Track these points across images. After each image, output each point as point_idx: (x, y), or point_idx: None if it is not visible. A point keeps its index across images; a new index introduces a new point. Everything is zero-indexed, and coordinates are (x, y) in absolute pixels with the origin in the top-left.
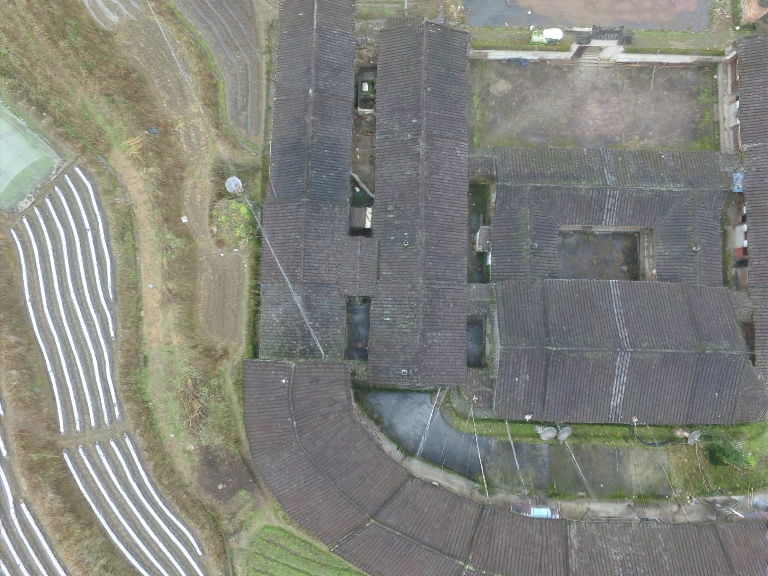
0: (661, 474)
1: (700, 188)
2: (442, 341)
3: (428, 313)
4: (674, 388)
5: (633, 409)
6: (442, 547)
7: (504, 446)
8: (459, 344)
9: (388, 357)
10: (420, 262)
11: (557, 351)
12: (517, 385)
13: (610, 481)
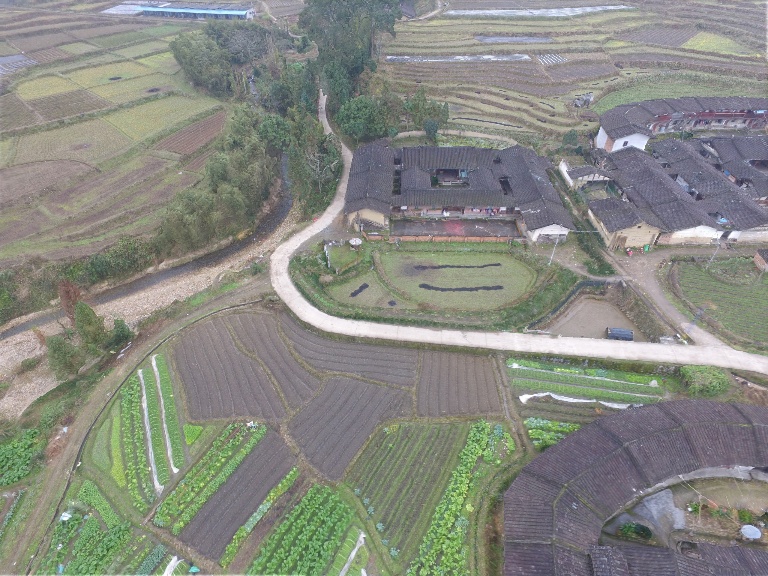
0: None
1: (765, 179)
2: None
3: None
4: None
5: None
6: None
7: None
8: None
9: None
10: None
11: None
12: None
13: (721, 133)
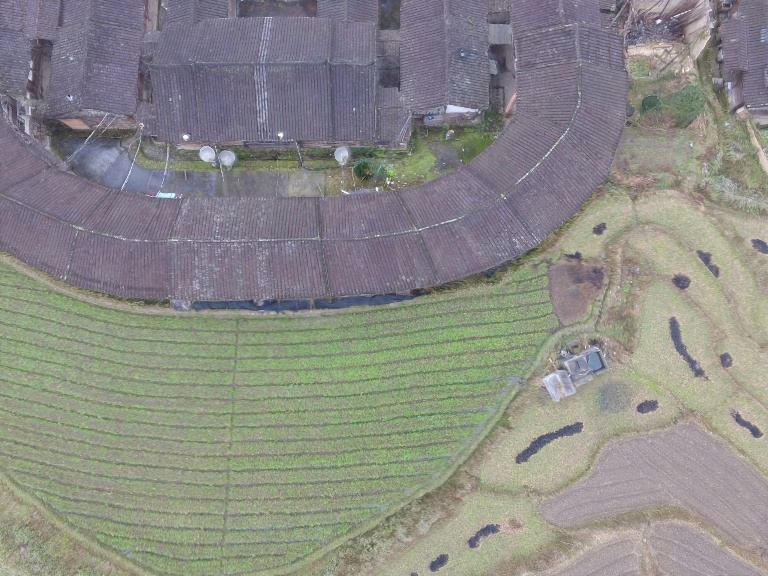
0: (317, 192)
1: None
2: (109, 73)
3: (95, 47)
4: (312, 102)
5: (279, 125)
6: (60, 215)
7: (177, 174)
8: (128, 78)
9: (61, 89)
10: (90, 4)
11: (197, 66)
12: (172, 106)
13: None
